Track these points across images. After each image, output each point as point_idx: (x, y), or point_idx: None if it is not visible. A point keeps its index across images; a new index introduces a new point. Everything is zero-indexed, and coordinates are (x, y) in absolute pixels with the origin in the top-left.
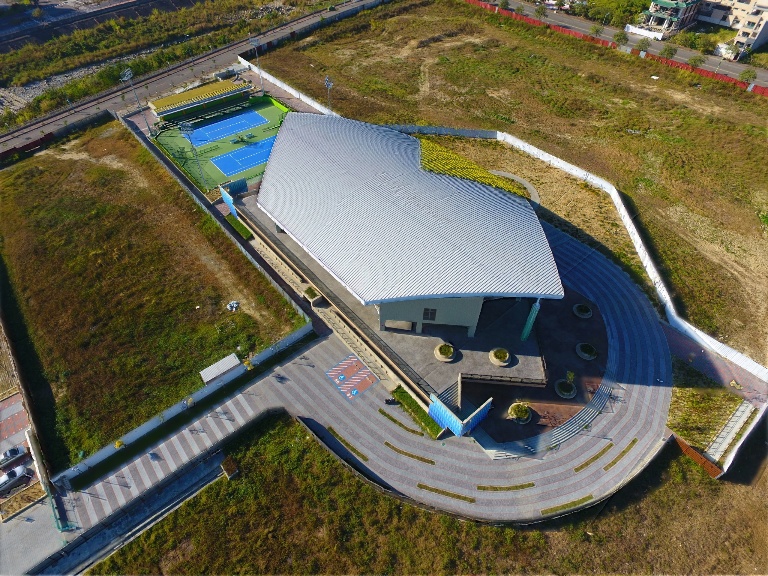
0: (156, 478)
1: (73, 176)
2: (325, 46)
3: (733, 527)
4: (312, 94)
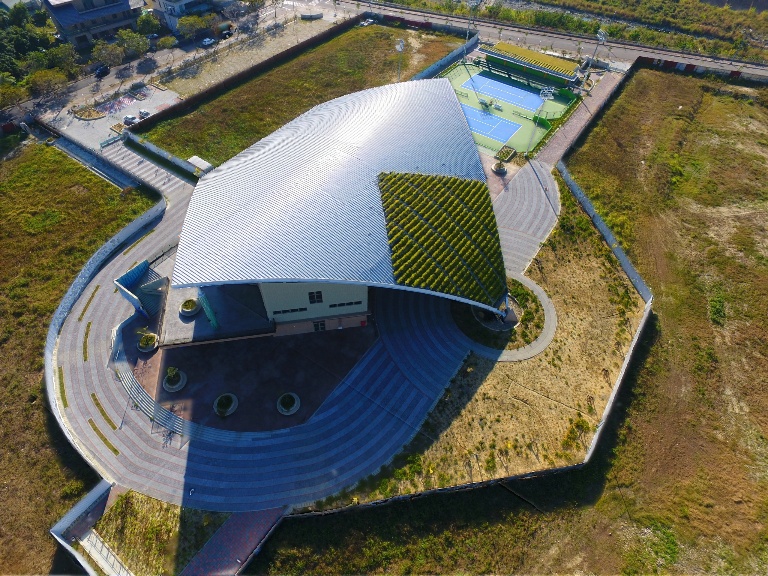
0: (127, 167)
1: (390, 51)
2: (749, 106)
3: (8, 542)
4: (608, 121)
